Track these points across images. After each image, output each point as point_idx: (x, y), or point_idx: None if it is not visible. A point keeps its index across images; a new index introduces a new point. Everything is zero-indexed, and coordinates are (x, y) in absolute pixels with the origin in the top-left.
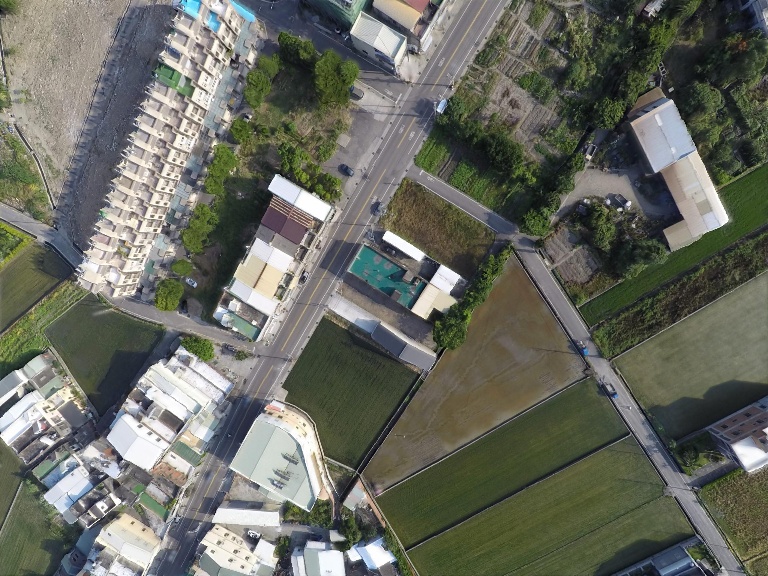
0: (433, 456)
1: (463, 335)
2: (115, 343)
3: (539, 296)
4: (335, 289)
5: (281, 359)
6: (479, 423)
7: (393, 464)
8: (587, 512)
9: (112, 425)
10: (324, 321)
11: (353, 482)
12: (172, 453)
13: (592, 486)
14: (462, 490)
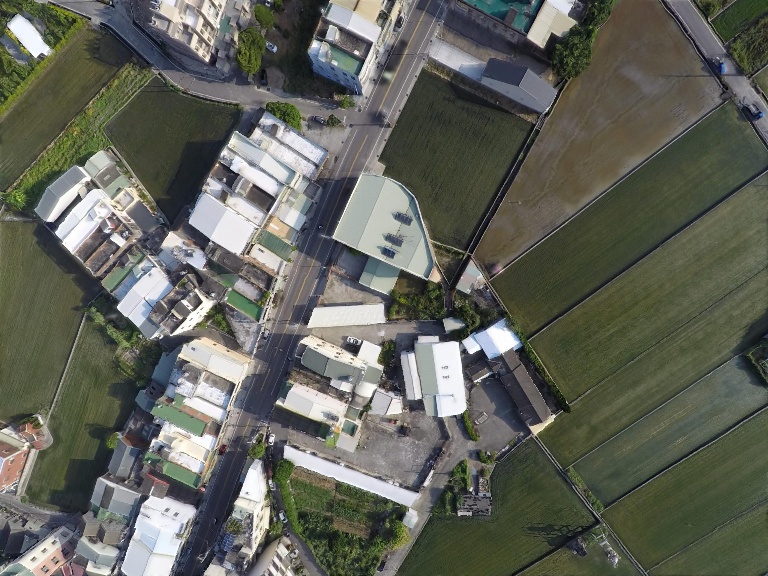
0: (553, 222)
1: (590, 53)
2: (185, 134)
3: (666, 12)
4: (435, 33)
5: (376, 126)
6: (604, 175)
7: (508, 238)
8: (732, 264)
9: (191, 214)
10: (423, 75)
11: (463, 266)
12: (260, 246)
13: (736, 232)
14: (588, 258)
